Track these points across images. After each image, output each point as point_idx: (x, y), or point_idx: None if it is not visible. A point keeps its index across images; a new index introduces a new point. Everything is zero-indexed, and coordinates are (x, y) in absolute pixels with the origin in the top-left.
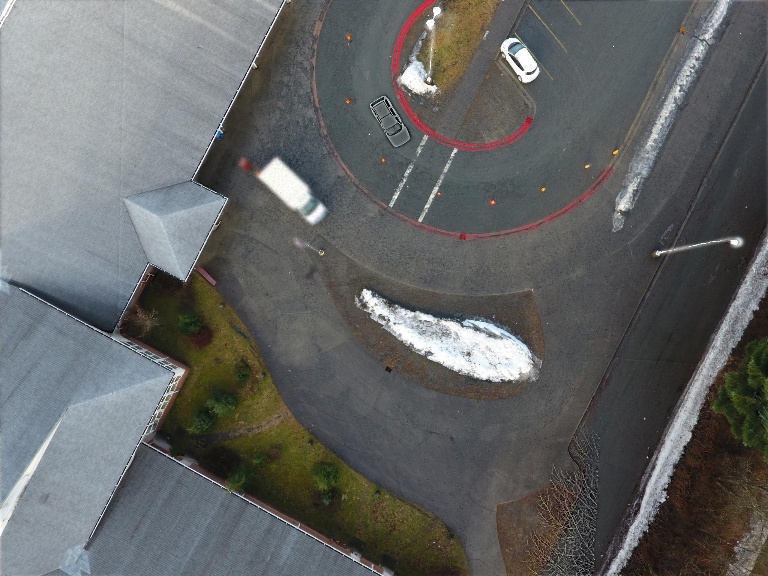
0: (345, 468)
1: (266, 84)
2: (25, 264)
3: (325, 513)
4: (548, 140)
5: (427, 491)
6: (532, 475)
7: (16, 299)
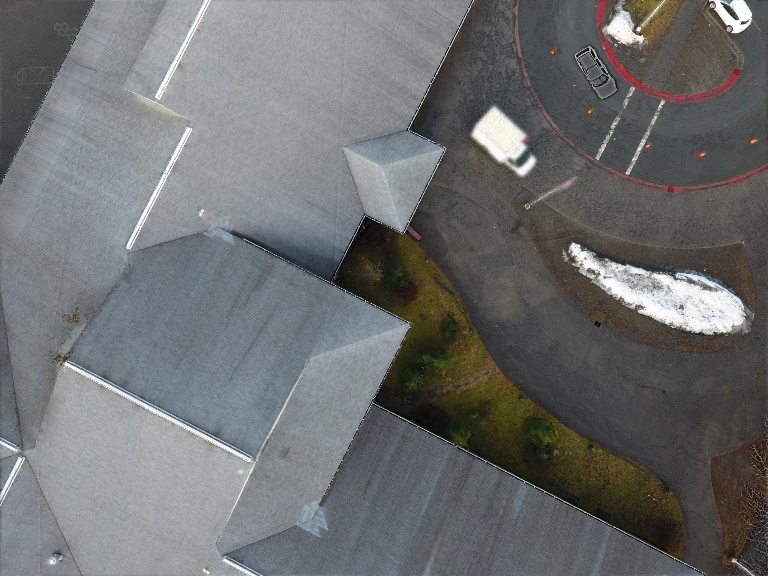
0: (556, 423)
1: (467, 34)
2: (247, 214)
3: (536, 469)
4: (756, 92)
5: (640, 445)
6: (745, 427)
7: (242, 250)
